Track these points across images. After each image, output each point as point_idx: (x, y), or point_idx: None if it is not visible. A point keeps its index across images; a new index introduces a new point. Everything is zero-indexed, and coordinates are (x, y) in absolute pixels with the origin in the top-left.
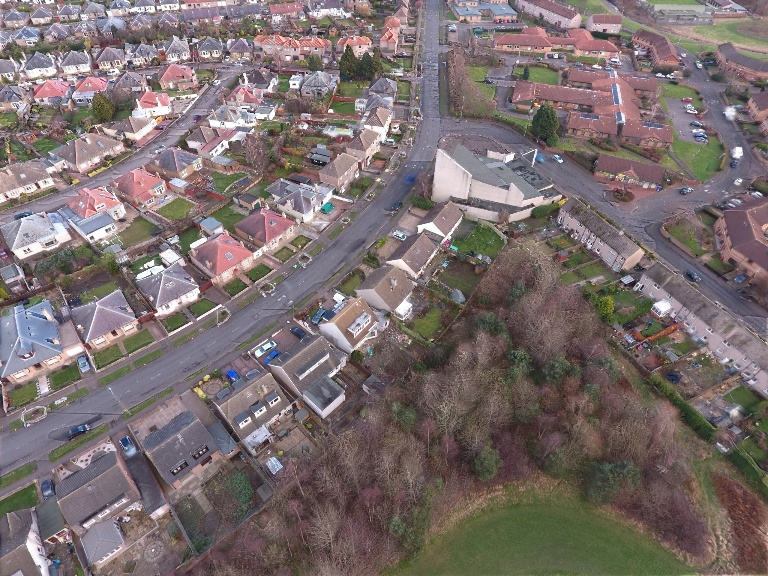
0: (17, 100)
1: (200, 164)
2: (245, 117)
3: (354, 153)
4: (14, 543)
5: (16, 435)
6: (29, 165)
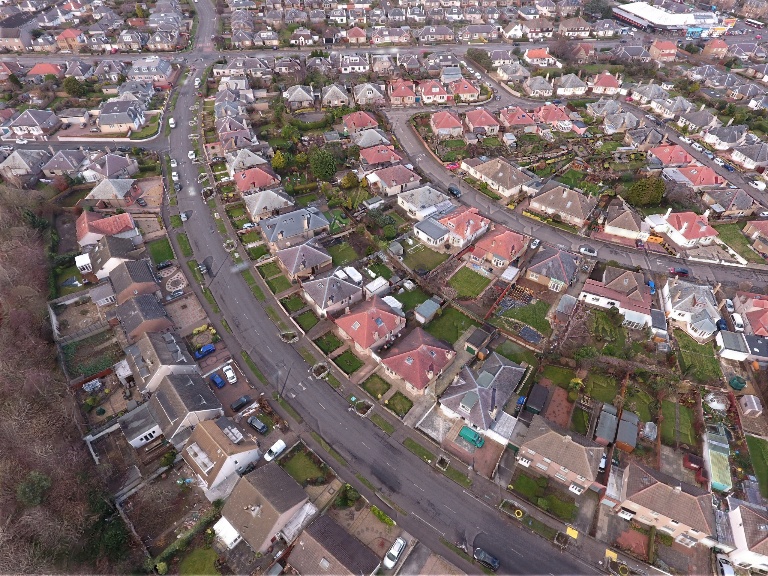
0: (638, 141)
1: (559, 287)
2: (696, 319)
3: (626, 480)
4: (119, 254)
5: (219, 242)
6: (517, 173)
